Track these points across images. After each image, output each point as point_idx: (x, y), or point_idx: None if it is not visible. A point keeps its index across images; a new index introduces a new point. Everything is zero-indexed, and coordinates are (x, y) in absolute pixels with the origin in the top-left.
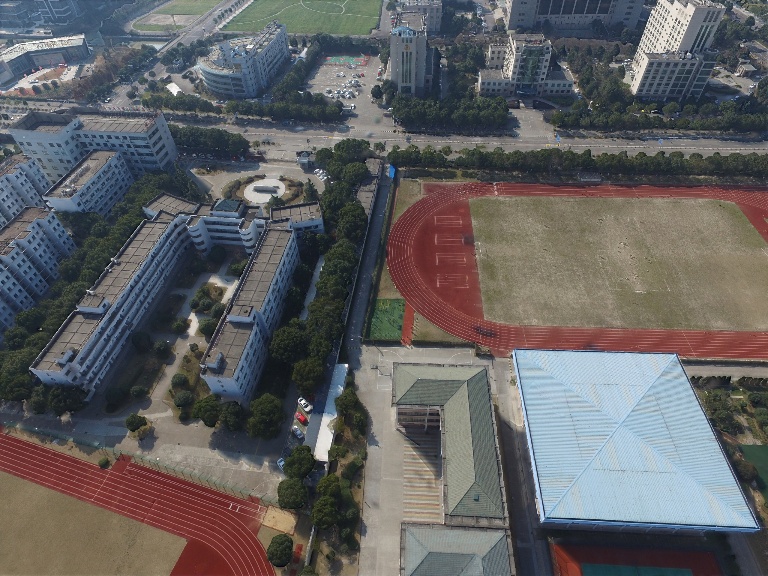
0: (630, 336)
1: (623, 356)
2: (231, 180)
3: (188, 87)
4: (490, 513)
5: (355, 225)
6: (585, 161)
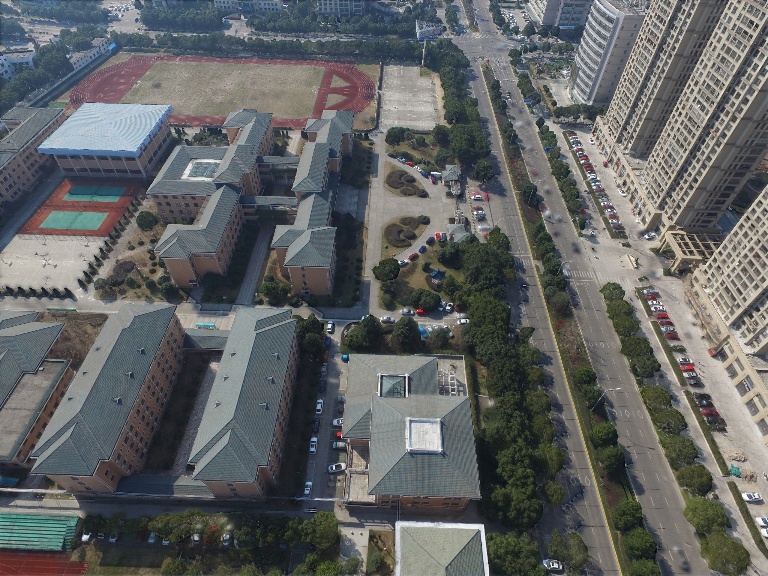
0: (189, 118)
1: (140, 105)
2: (2, 50)
3: (8, 2)
4: (13, 148)
5: (51, 62)
6: (238, 41)
